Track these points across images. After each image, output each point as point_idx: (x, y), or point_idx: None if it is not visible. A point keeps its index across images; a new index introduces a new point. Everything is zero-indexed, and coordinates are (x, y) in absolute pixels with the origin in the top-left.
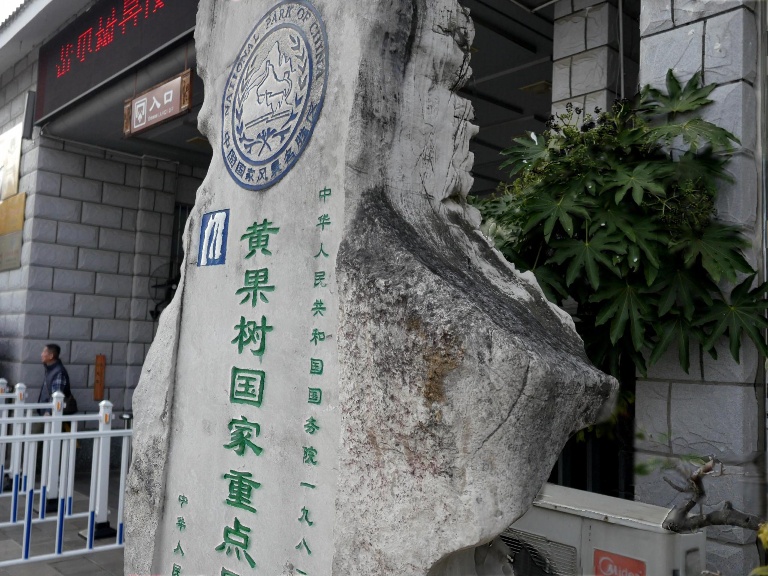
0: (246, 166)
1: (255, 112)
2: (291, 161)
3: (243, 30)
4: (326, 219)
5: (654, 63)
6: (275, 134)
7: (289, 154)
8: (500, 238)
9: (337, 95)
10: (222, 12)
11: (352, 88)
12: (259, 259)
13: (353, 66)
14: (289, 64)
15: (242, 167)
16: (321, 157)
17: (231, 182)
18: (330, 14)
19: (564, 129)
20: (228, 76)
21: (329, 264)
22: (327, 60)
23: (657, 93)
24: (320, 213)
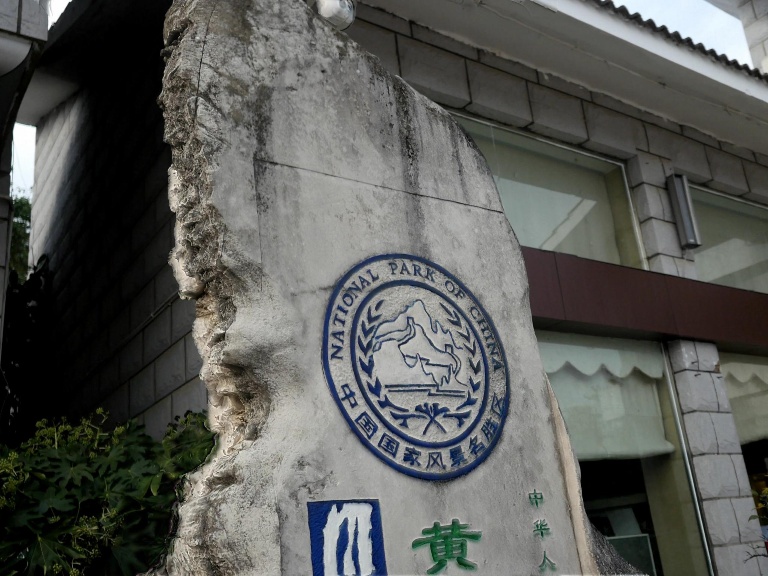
0: (400, 443)
1: (404, 375)
2: (481, 452)
3: (343, 252)
4: (544, 525)
5: None
6: (450, 414)
7: (475, 443)
8: None
9: (527, 397)
10: (284, 200)
11: (542, 396)
12: (456, 573)
13: (538, 375)
14: (450, 337)
15: (394, 443)
16: (522, 457)
17: (373, 460)
18: (495, 309)
19: None
20: (327, 302)
21: (559, 574)
22: (505, 356)
23: None
24: (536, 518)
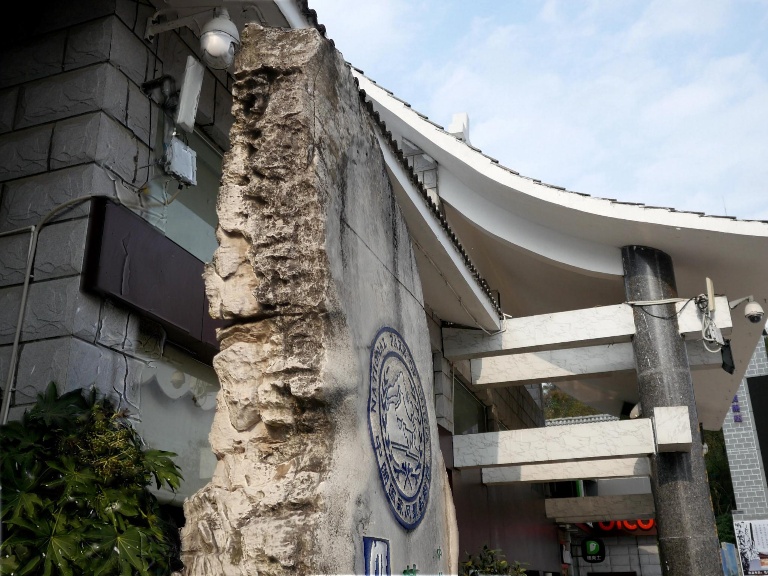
0: None
1: (398, 435)
2: None
3: (374, 318)
4: None
5: (107, 375)
6: None
7: None
8: (160, 553)
9: None
10: None
11: None
12: None
13: None
14: None
15: None
16: None
17: (387, 506)
18: None
19: (142, 435)
20: (370, 360)
21: None
22: None
23: (108, 405)
24: None
